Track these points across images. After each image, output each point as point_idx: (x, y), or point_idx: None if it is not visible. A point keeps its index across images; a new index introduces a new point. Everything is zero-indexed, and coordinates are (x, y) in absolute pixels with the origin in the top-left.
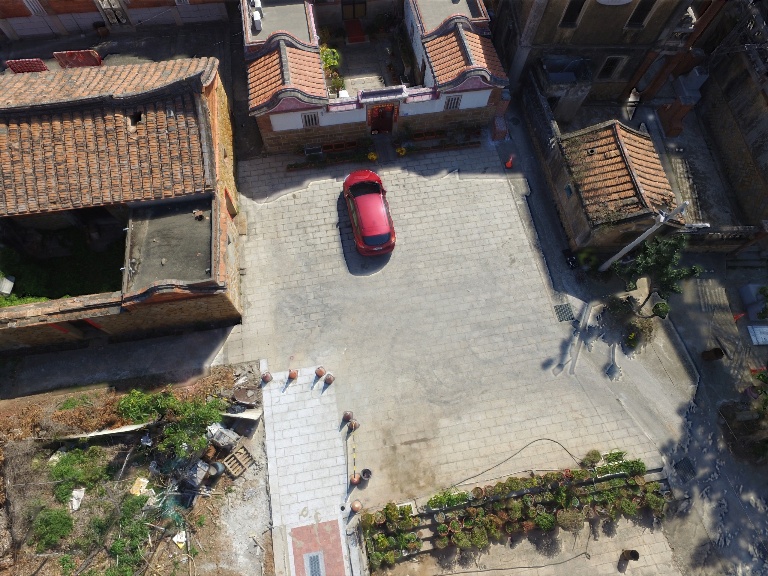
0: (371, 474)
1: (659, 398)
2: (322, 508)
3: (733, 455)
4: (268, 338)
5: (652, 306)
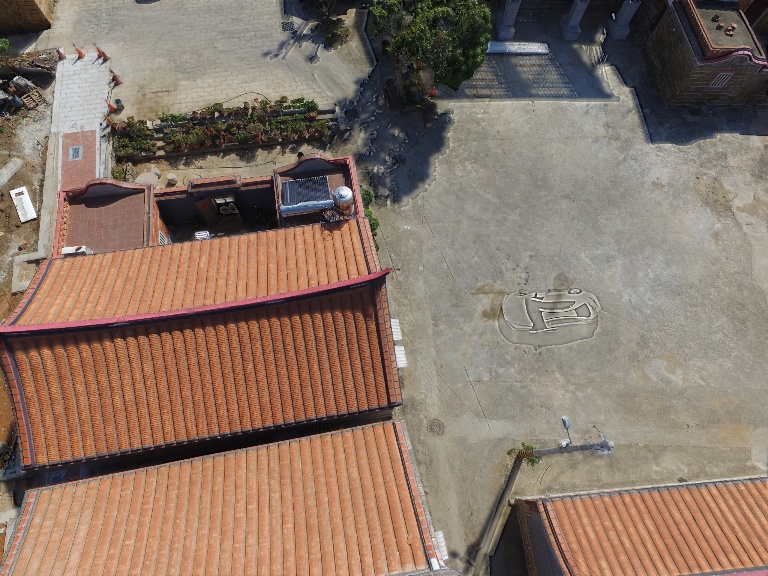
0: (121, 102)
1: (343, 74)
2: (86, 124)
3: (389, 107)
4: (68, 36)
5: (354, 24)
